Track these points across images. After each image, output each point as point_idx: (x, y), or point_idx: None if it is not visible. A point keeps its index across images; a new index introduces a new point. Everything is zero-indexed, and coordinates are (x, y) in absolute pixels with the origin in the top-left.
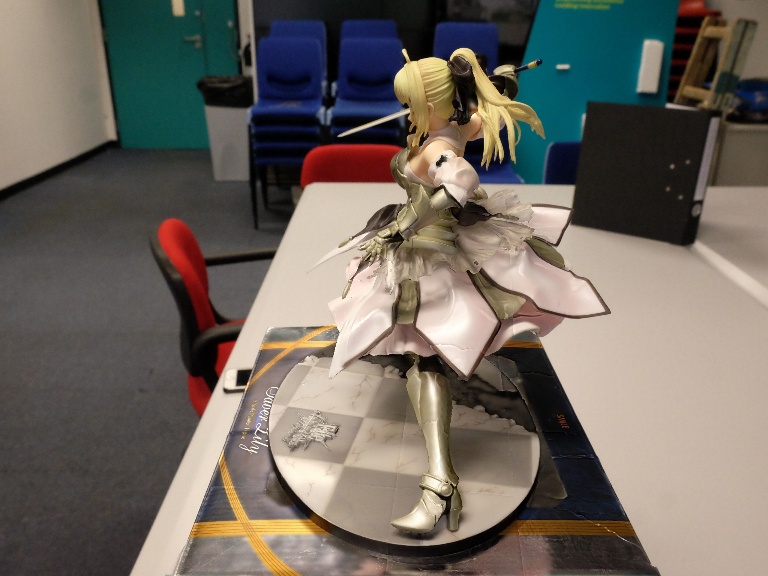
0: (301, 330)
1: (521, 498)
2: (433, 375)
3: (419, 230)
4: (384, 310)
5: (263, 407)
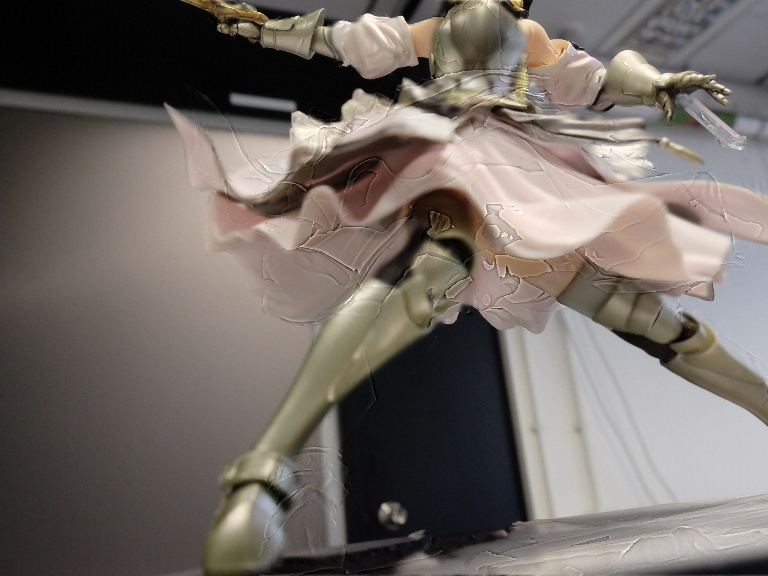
0: None
1: None
2: None
3: None
4: None
5: None
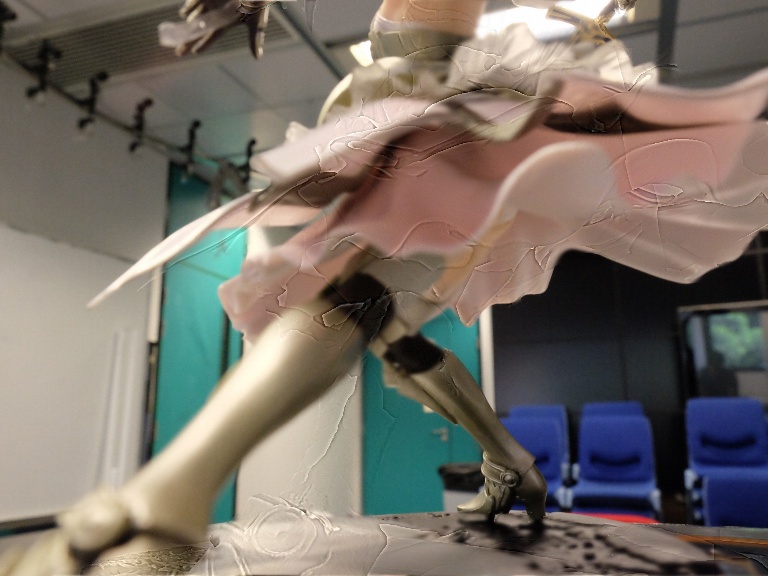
0: None
1: None
2: None
3: None
4: None
5: None
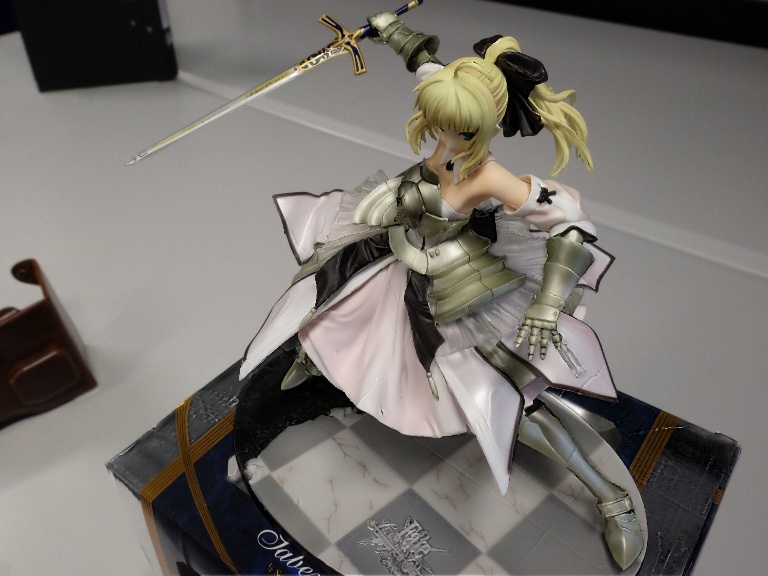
0: (158, 436)
1: (615, 454)
2: (544, 411)
3: (480, 274)
4: (498, 384)
5: (292, 567)
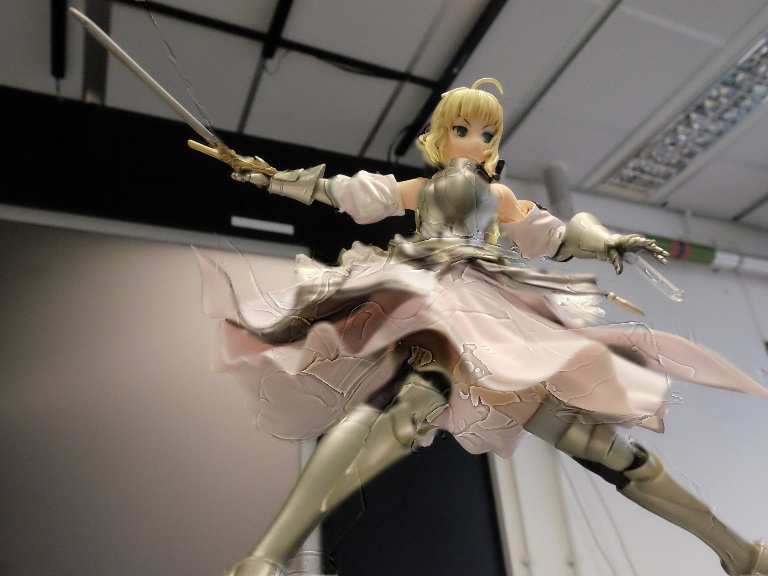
0: None
1: None
2: None
3: None
4: None
5: None
